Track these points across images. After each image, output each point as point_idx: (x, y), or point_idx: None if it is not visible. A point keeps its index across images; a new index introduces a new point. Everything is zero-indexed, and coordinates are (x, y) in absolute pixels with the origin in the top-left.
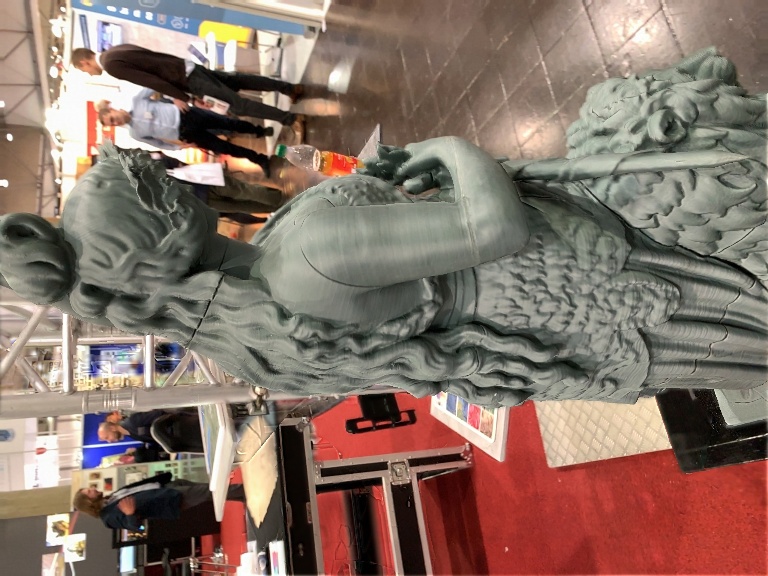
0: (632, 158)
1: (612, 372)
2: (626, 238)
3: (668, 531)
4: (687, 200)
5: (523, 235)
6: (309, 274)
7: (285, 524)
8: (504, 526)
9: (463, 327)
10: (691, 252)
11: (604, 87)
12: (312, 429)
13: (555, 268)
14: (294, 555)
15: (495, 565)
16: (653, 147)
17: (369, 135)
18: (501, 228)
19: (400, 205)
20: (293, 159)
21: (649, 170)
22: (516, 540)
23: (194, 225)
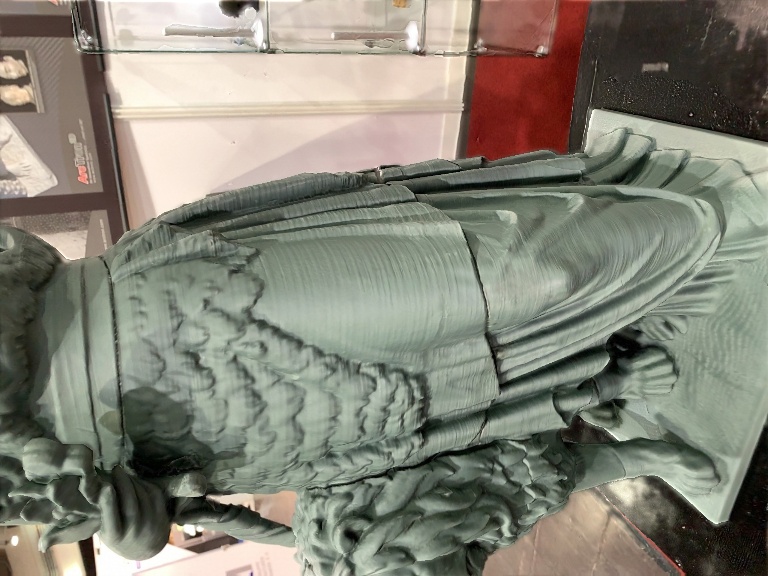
0: None
1: None
2: None
3: None
4: None
5: None
6: None
7: None
8: None
9: None
10: None
11: None
12: None
13: None
14: None
15: None
16: None
17: None
18: None
19: None
20: None
21: None
22: None
23: None
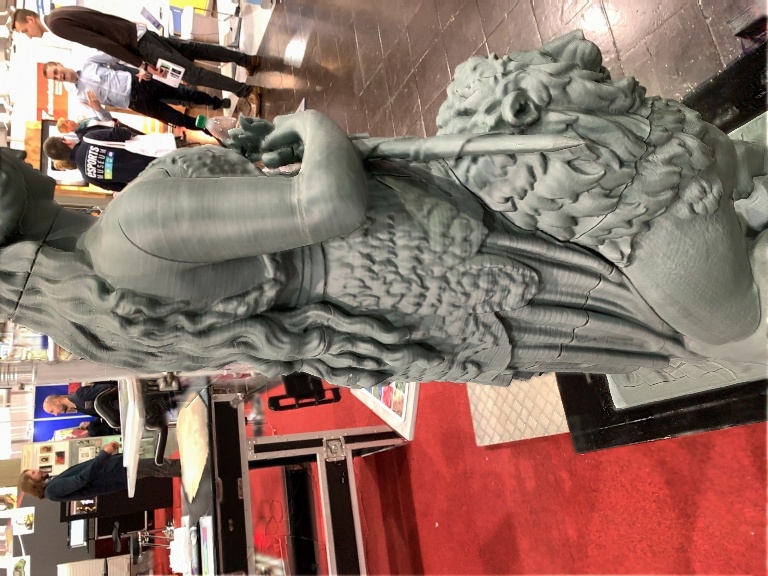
0: (477, 139)
1: (474, 355)
2: (483, 221)
3: (582, 508)
4: (539, 184)
5: (357, 214)
6: (126, 247)
7: (214, 500)
8: (435, 502)
9: (310, 306)
10: (551, 237)
11: (466, 66)
12: (247, 405)
13: (406, 249)
14: (223, 530)
15: (426, 540)
16: (506, 129)
17: (295, 108)
18: (332, 206)
19: (232, 179)
20: (213, 130)
21: (493, 152)
22: (446, 516)
23: (7, 192)
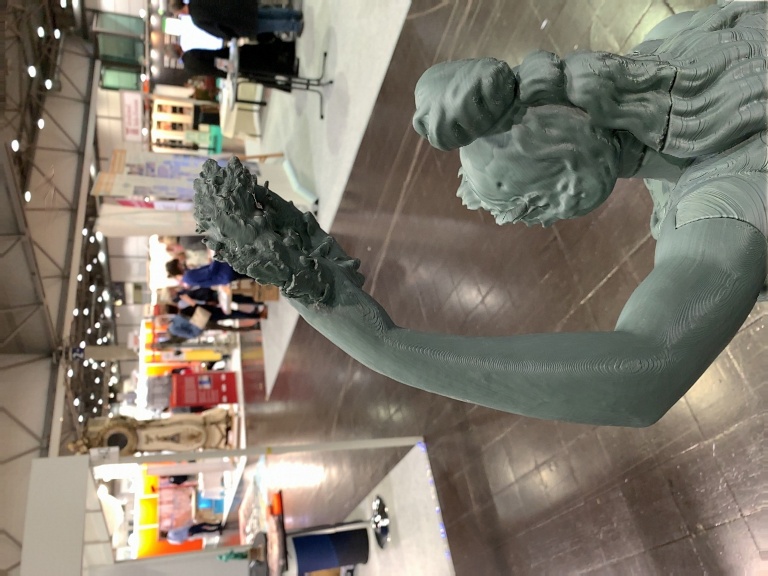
0: None
1: None
2: None
3: None
4: None
5: None
6: None
7: None
8: None
9: None
10: None
11: None
12: None
13: None
14: None
15: None
16: None
17: None
18: None
19: None
20: None
21: None
22: None
23: None
